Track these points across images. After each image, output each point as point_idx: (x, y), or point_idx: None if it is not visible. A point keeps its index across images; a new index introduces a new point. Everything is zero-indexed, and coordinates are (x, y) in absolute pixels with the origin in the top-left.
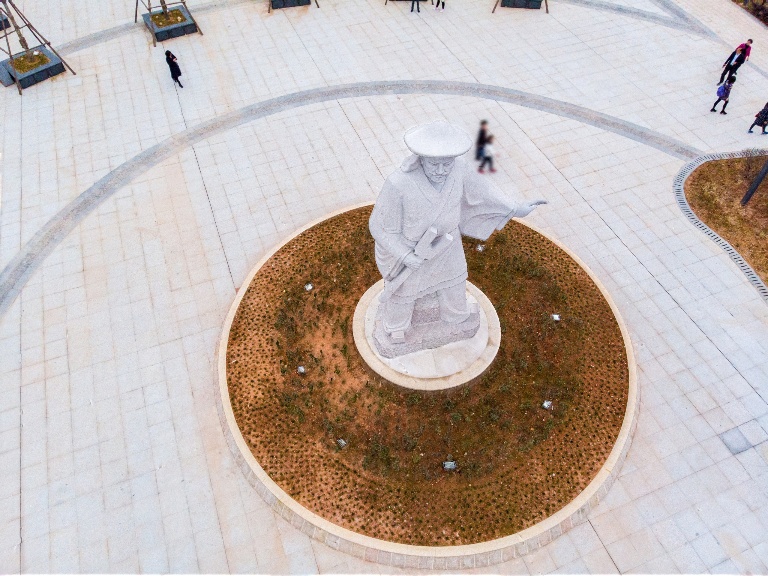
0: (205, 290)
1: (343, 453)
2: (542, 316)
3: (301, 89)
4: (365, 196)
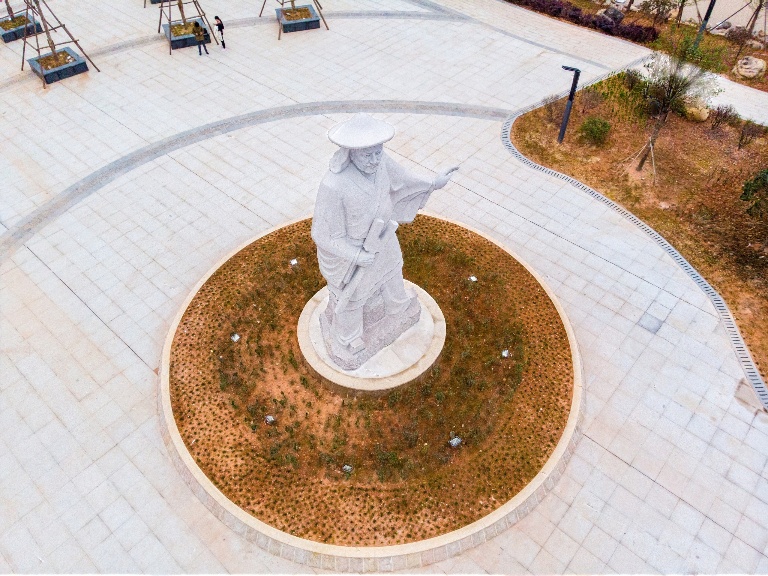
0: (119, 385)
1: (353, 478)
2: (463, 282)
3: (122, 154)
4: (244, 235)
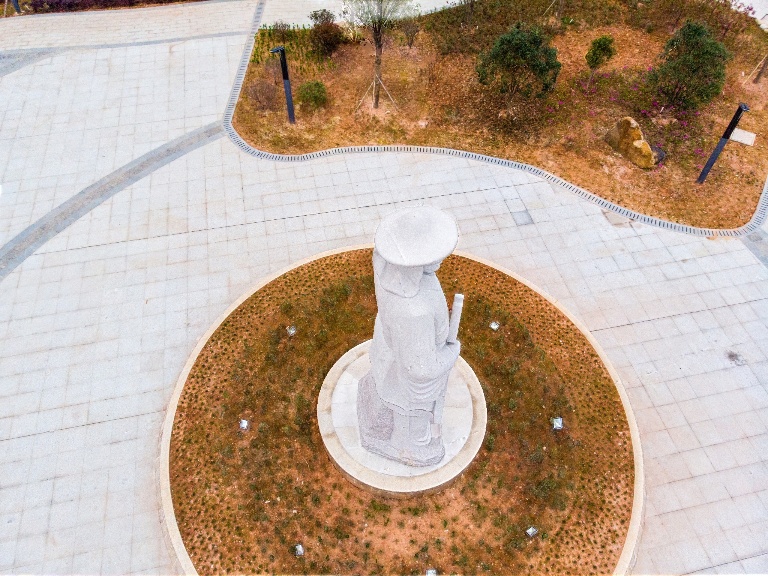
0: None
1: None
2: None
3: None
4: (137, 452)
